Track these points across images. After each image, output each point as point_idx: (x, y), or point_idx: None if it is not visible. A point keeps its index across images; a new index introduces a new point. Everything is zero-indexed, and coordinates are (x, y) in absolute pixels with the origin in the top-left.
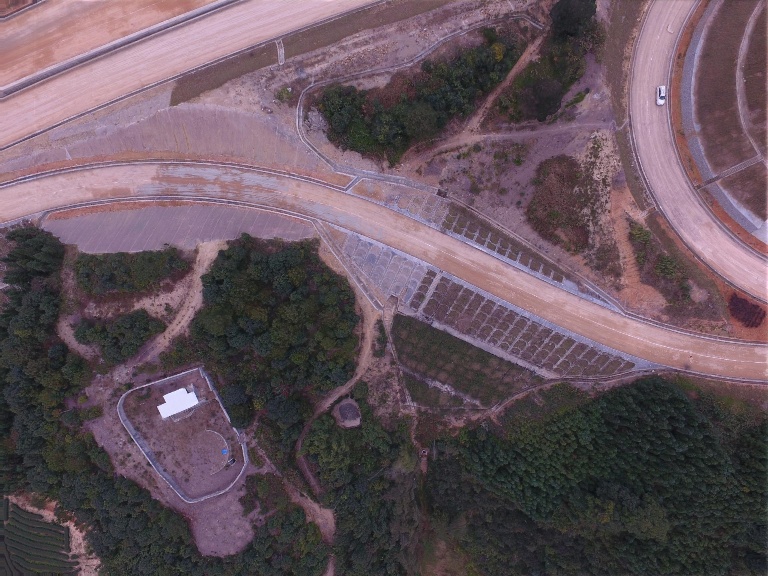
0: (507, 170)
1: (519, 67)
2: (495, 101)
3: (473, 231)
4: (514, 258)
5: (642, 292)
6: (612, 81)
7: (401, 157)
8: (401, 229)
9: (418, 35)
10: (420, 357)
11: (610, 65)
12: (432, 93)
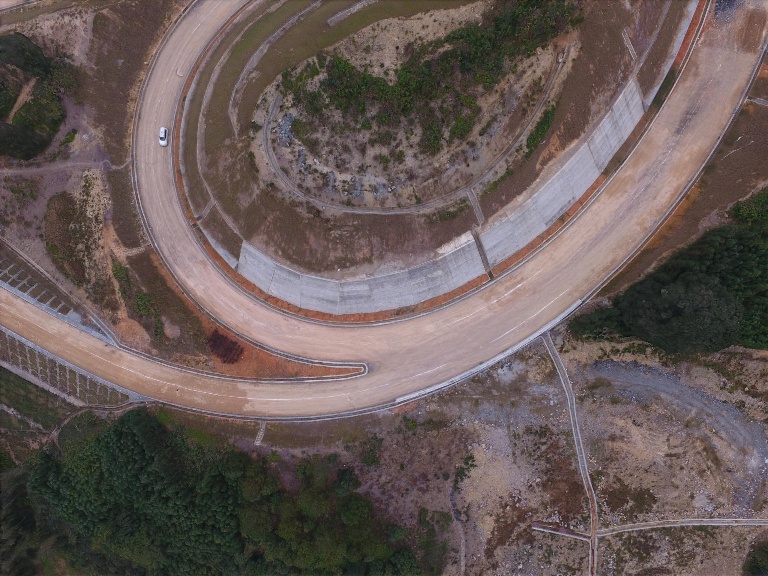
0: (27, 204)
1: (19, 107)
2: None
3: None
4: (24, 290)
5: (135, 326)
6: (106, 122)
7: None
8: None
9: None
10: None
11: (102, 107)
12: None
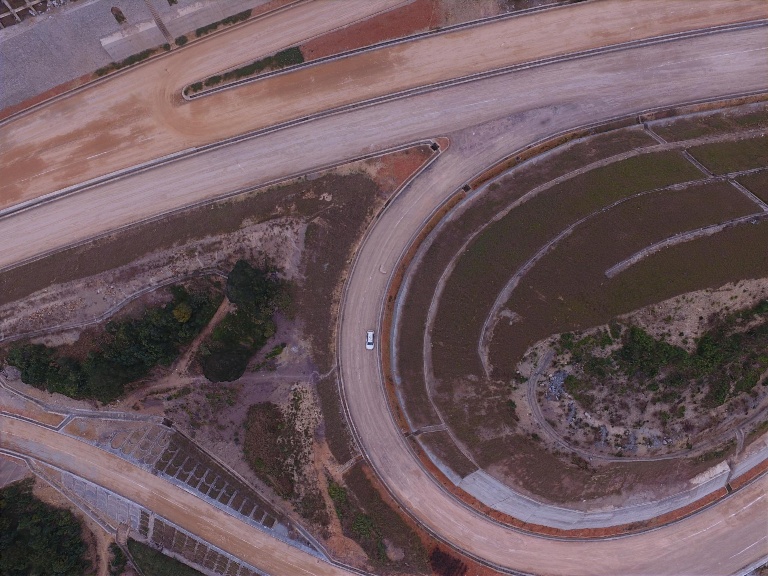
0: (222, 409)
1: (220, 316)
2: (198, 348)
3: (189, 470)
4: (225, 501)
5: (348, 541)
6: (313, 331)
7: None
8: (114, 469)
9: (104, 293)
10: None
11: (310, 316)
12: (117, 355)
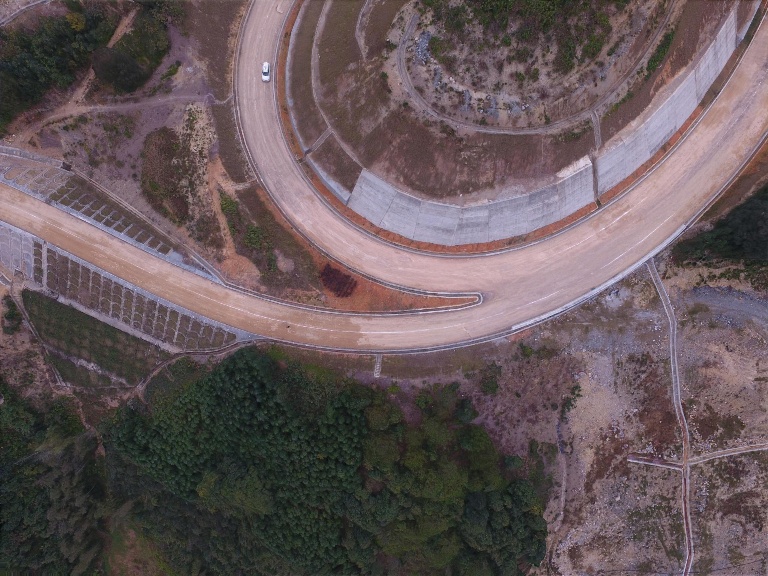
0: (120, 142)
1: (117, 39)
2: None
3: (84, 203)
4: (120, 230)
5: (242, 263)
6: (209, 56)
7: (8, 127)
8: (6, 200)
9: None
10: (56, 334)
11: (206, 40)
12: (8, 60)
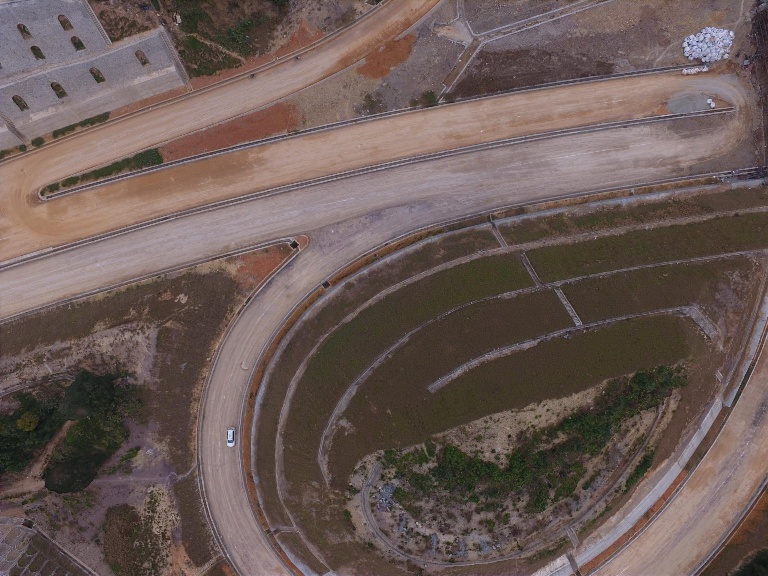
0: (81, 510)
1: None
2: None
3: (46, 574)
4: None
5: None
6: (170, 432)
7: None
8: None
9: None
10: None
11: (166, 417)
12: None
